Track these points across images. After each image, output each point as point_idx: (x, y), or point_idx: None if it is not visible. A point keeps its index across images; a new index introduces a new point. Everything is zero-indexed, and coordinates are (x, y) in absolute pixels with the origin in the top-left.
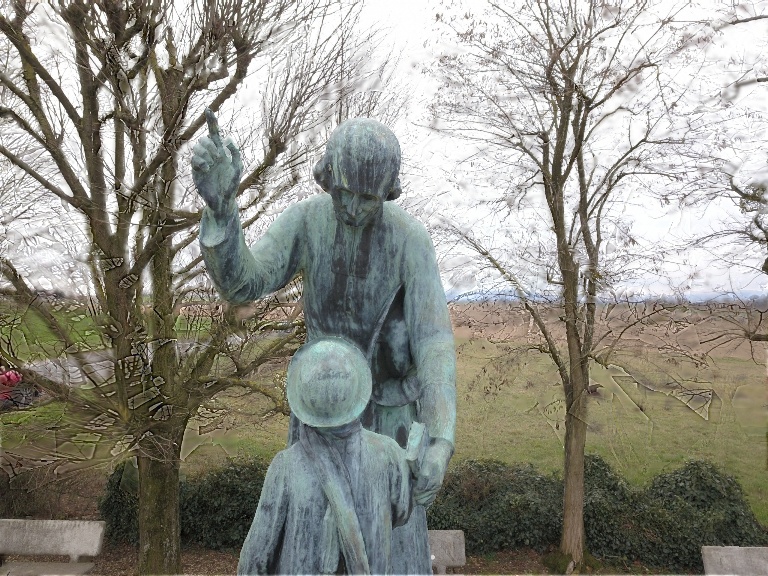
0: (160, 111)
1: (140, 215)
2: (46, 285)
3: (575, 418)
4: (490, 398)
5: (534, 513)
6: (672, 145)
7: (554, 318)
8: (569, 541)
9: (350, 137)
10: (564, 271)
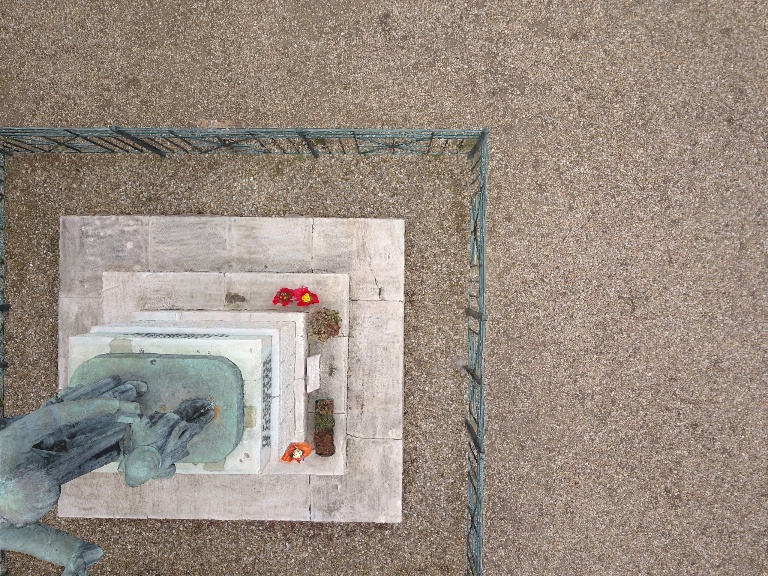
0: None
1: None
2: None
3: None
4: None
5: None
6: None
7: None
8: None
9: None
10: None
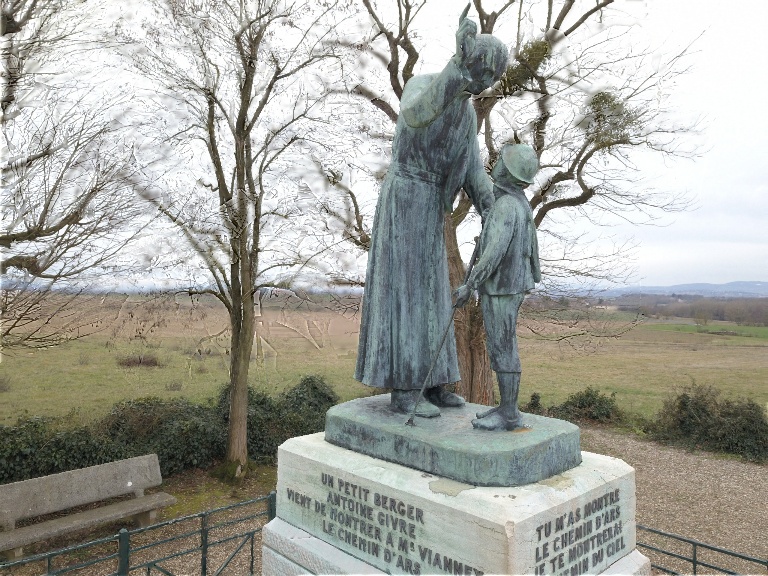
0: None
1: None
2: None
3: (244, 342)
4: (137, 342)
5: (202, 434)
6: (322, 124)
7: None
8: (237, 449)
9: (500, 43)
10: None
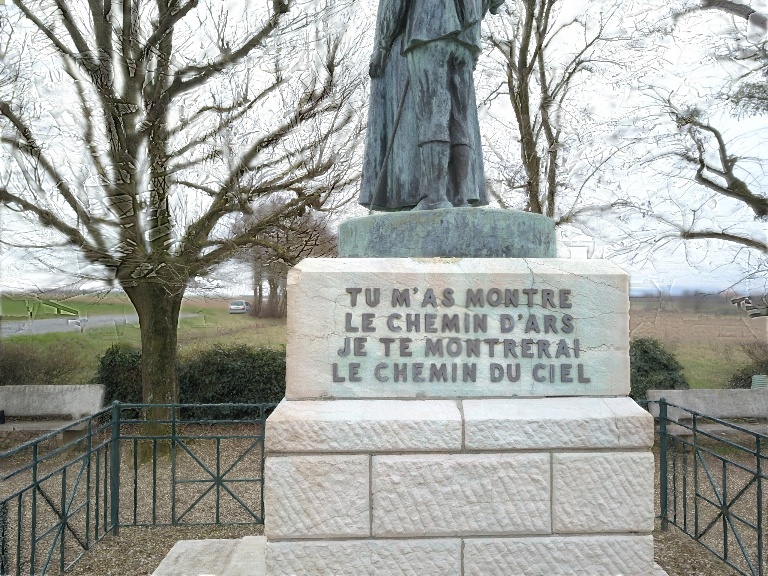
0: (153, 3)
1: (155, 64)
2: (68, 120)
3: None
4: None
5: None
6: (621, 42)
7: None
8: None
9: None
10: (529, 154)
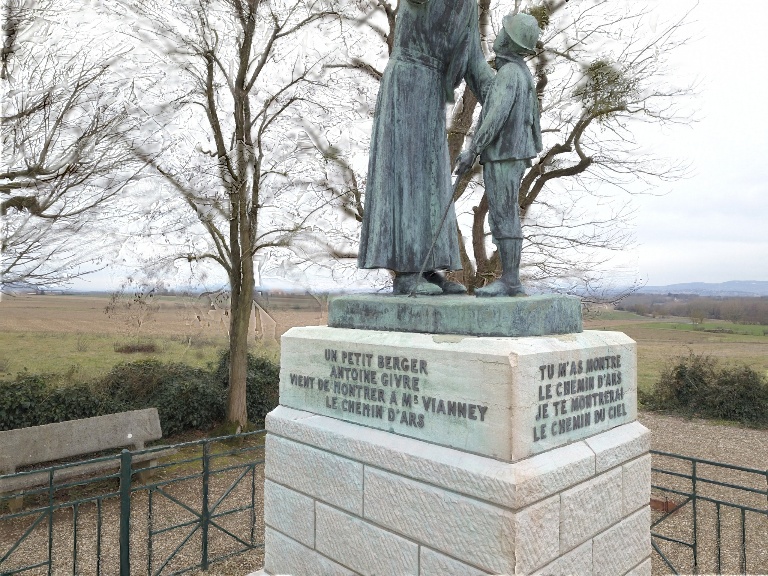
0: None
1: None
2: None
3: (244, 303)
4: (136, 307)
5: (202, 395)
6: (321, 87)
7: (201, 230)
8: (236, 410)
9: None
10: None
